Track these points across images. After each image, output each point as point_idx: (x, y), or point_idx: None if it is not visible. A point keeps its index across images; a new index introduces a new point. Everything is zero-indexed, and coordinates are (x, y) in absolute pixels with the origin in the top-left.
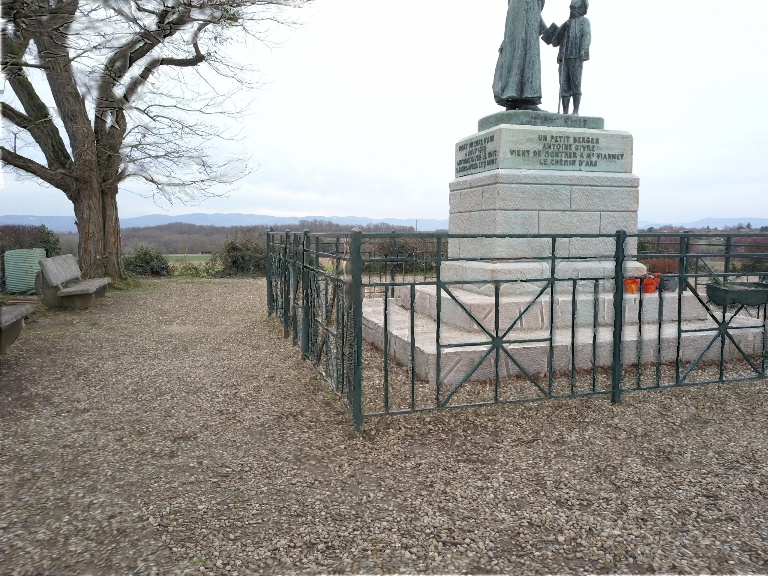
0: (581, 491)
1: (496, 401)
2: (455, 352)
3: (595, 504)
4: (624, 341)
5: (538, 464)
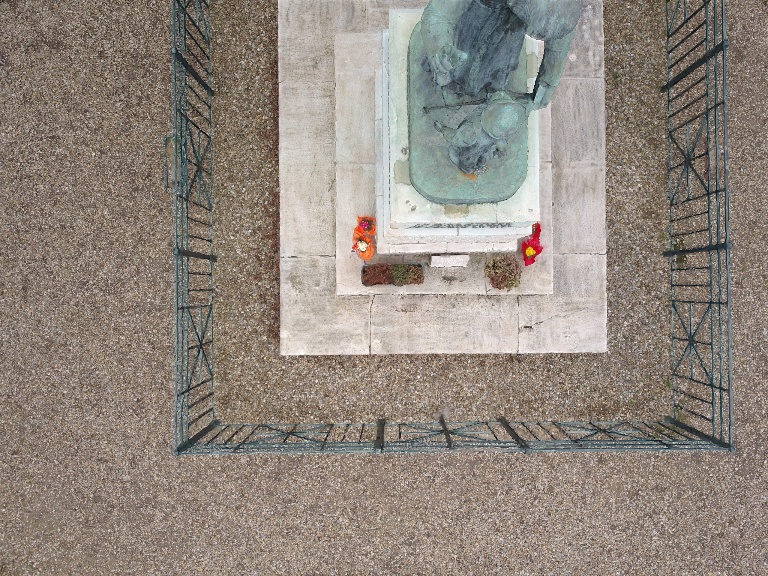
0: (121, 6)
1: (207, 7)
2: (278, 6)
3: (109, 4)
4: (279, 151)
5: (152, 5)
